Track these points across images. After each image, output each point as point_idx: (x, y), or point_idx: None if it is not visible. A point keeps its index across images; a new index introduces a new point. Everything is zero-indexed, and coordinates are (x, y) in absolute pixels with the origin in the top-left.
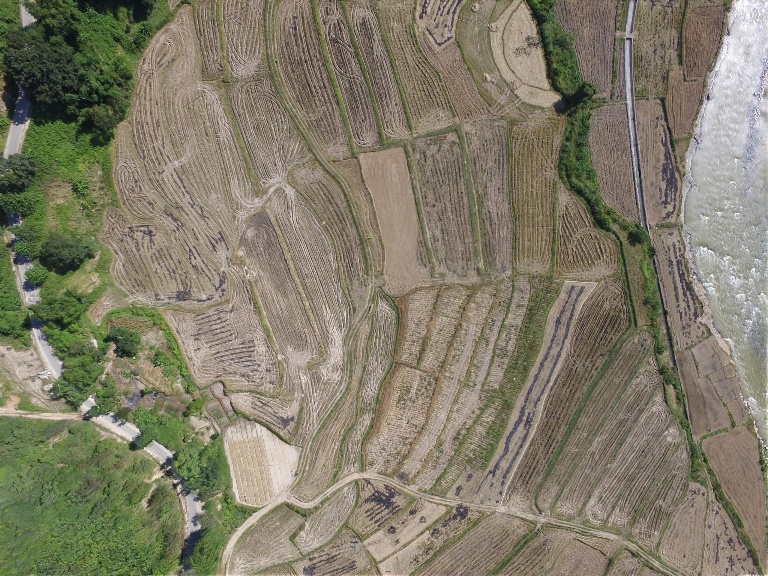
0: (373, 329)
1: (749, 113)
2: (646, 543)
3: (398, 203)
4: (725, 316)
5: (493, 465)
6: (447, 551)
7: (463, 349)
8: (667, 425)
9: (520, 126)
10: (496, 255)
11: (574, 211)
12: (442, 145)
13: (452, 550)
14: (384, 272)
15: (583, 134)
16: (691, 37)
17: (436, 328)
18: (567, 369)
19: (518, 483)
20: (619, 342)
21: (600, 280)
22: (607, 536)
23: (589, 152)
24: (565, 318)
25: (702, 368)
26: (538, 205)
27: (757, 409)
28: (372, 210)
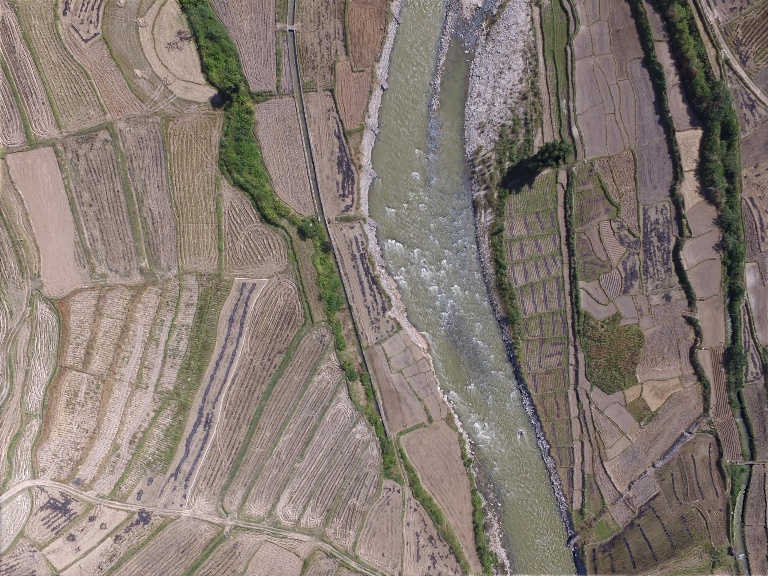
0: (34, 333)
1: (427, 103)
2: (342, 543)
3: (51, 204)
4: (420, 309)
5: (174, 468)
6: (133, 557)
7: (132, 351)
8: (354, 422)
9: (176, 122)
10: (160, 254)
11: (239, 207)
12: (94, 143)
13: (139, 556)
14: (41, 274)
15: (240, 128)
16: (355, 27)
17: (101, 330)
18: (244, 368)
19: (202, 486)
20: (296, 339)
21: (272, 276)
22: (299, 537)
23: (259, 147)
24: (238, 316)
25: (394, 363)
26: (201, 202)
27: (459, 403)
28: (24, 211)
